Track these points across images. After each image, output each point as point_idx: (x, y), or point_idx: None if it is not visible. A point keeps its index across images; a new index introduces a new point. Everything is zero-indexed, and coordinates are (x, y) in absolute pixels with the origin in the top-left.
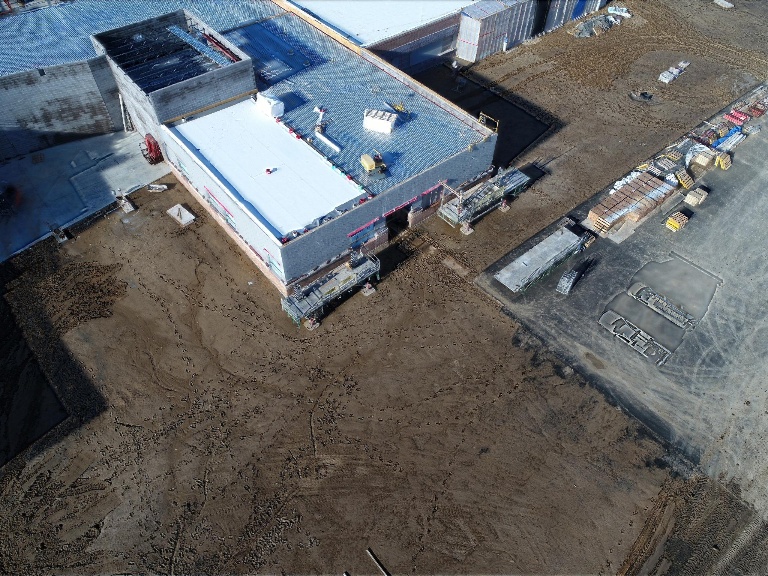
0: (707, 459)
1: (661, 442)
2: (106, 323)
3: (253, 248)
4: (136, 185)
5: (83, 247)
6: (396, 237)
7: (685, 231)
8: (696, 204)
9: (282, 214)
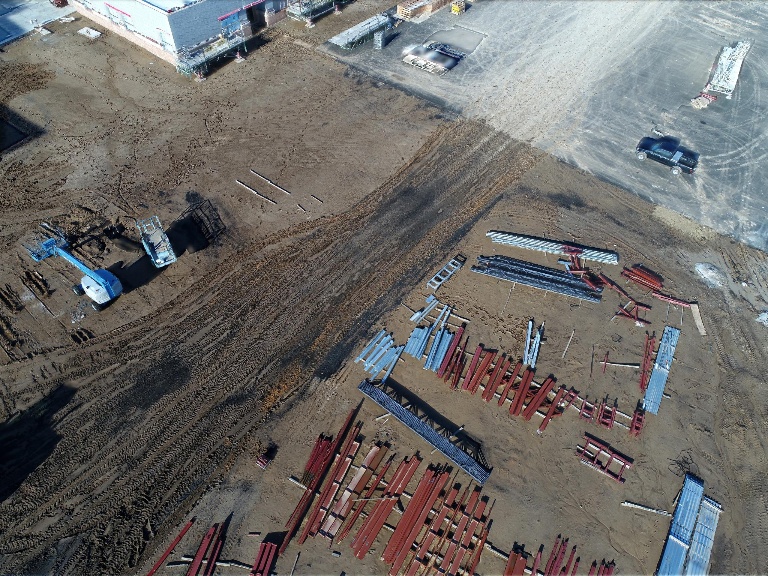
0: (467, 111)
1: (439, 107)
2: (44, 92)
3: (149, 37)
4: (49, 20)
5: (14, 56)
6: (258, 33)
7: (465, 14)
8: (474, 0)
9: (166, 2)
